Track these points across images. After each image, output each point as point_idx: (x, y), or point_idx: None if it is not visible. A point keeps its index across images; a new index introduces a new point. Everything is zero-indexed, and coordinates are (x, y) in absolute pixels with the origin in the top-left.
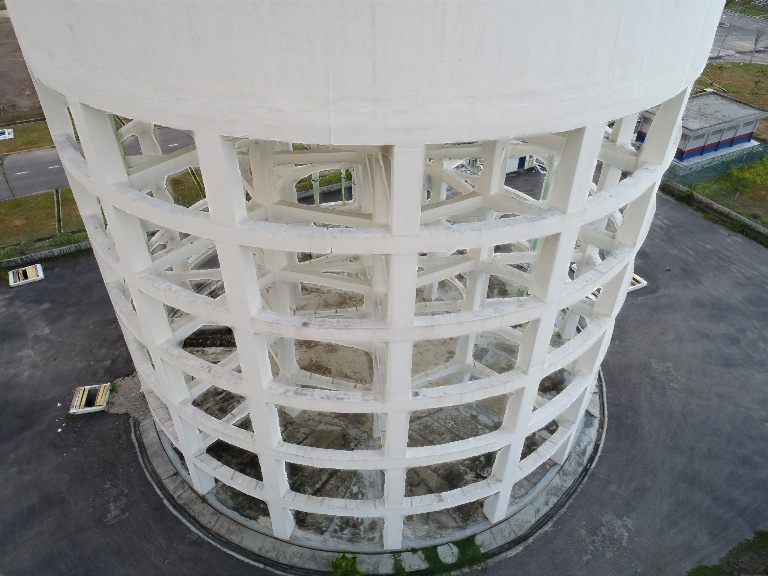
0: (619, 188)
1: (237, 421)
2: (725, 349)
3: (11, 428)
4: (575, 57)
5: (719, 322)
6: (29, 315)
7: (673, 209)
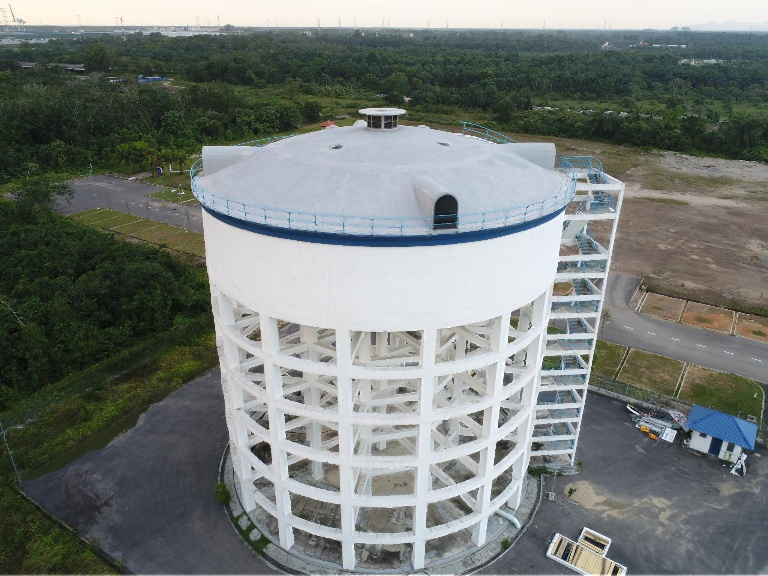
0: (299, 360)
1: None
2: None
3: (253, 368)
4: (248, 282)
5: None
6: None
7: None
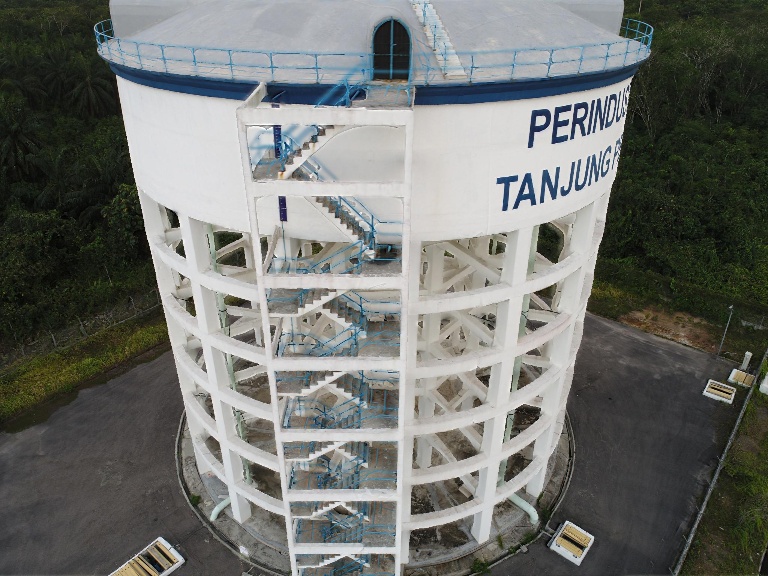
0: None
1: None
2: (26, 526)
3: None
4: None
5: (3, 568)
6: (653, 367)
7: None
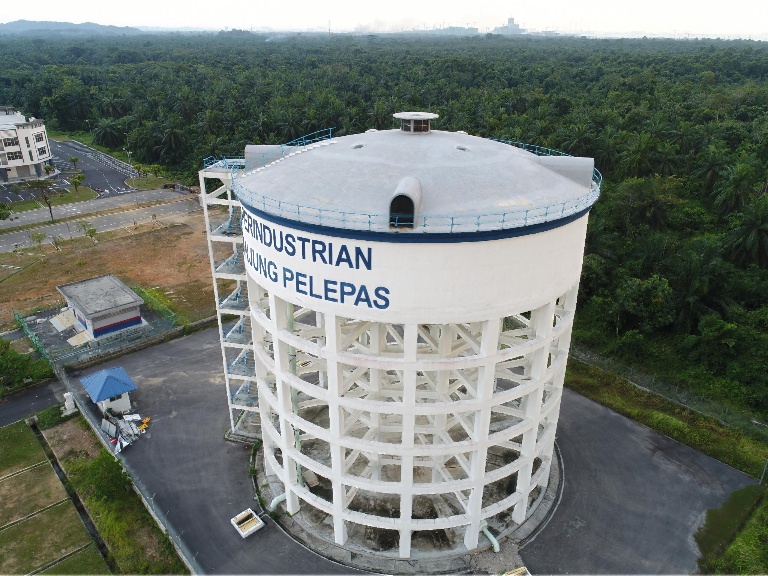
0: None
1: (495, 485)
2: None
3: None
4: None
5: None
6: None
7: (203, 337)
